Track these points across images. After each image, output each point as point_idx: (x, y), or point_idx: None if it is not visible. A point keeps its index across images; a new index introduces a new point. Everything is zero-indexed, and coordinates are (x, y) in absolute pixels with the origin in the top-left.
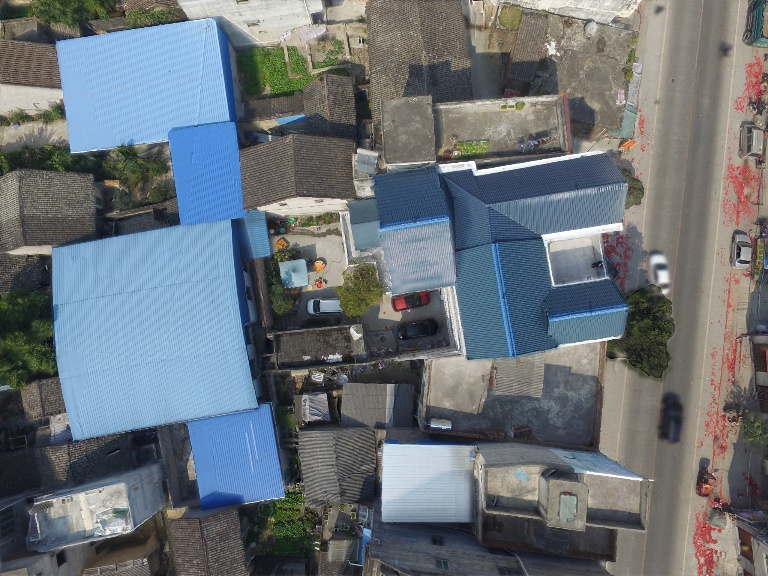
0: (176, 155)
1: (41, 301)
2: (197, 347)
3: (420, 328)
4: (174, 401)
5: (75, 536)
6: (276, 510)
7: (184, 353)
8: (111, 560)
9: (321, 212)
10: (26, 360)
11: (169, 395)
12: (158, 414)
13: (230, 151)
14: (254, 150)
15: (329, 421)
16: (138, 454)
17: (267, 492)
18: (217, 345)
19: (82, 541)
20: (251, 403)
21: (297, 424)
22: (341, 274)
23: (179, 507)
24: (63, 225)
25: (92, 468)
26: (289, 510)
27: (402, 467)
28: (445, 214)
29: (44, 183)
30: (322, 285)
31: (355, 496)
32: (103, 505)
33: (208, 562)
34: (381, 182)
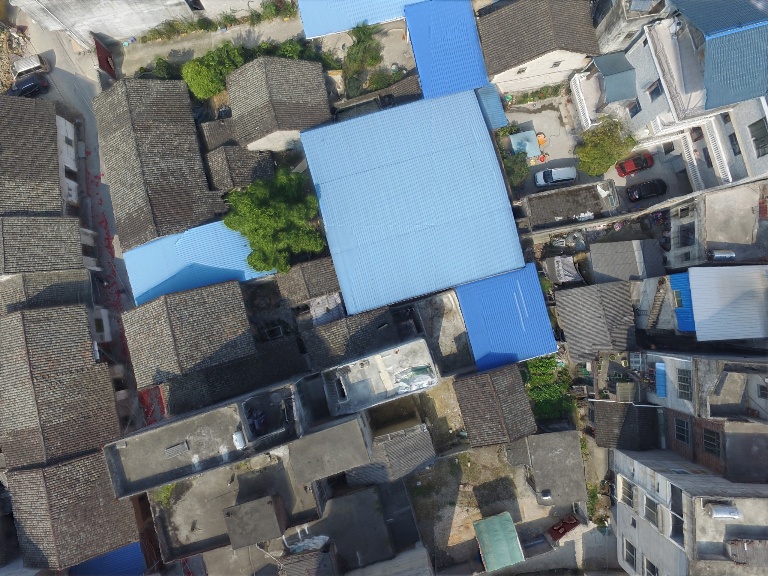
0: (414, 30)
1: (304, 180)
2: (464, 211)
3: (651, 188)
4: (444, 267)
5: (377, 398)
6: (531, 376)
7: (451, 218)
8: (392, 430)
9: (540, 86)
10: (289, 243)
11: (439, 261)
12: (429, 281)
13: (467, 22)
14: (497, 15)
15: (581, 281)
16: (399, 330)
17: (540, 348)
18: (483, 207)
19: (390, 398)
20: (518, 262)
21: (550, 287)
22: (561, 147)
23: (447, 376)
24: (305, 111)
25: (368, 341)
26: (544, 375)
27: (708, 288)
28: (767, 17)
29: (284, 70)
30: (545, 159)
31: (623, 345)
32: (400, 366)
33: (503, 413)
34: (683, 3)
